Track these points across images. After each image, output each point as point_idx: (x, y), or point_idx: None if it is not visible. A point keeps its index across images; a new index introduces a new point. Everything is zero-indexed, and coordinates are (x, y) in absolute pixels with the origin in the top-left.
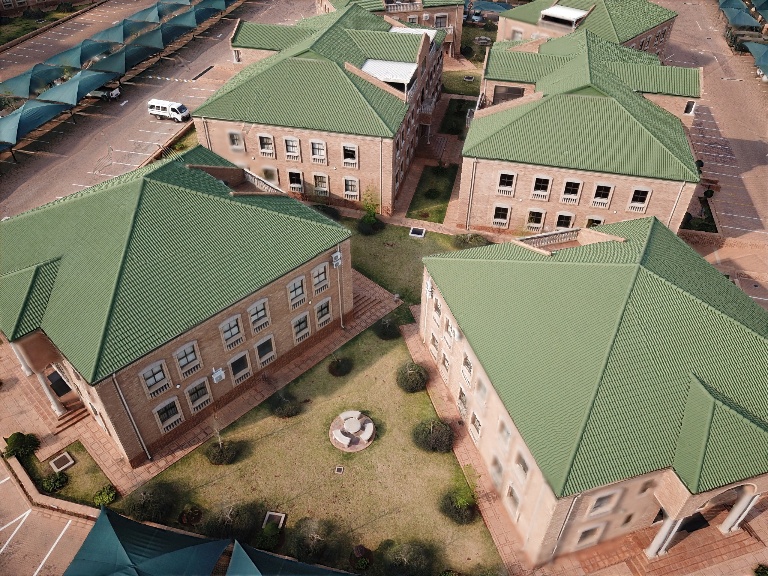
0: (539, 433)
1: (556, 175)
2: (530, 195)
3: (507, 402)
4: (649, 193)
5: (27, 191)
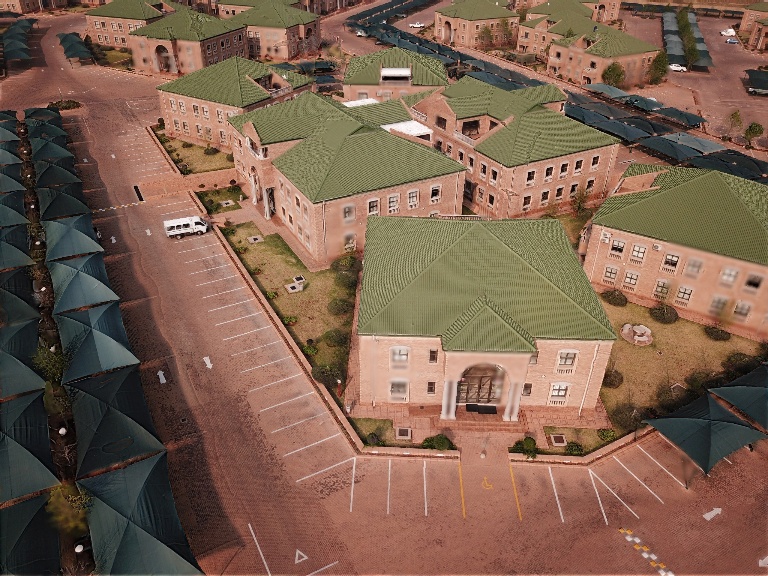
0: (764, 256)
1: (556, 162)
2: (543, 181)
3: (733, 254)
4: (600, 157)
5: (178, 334)
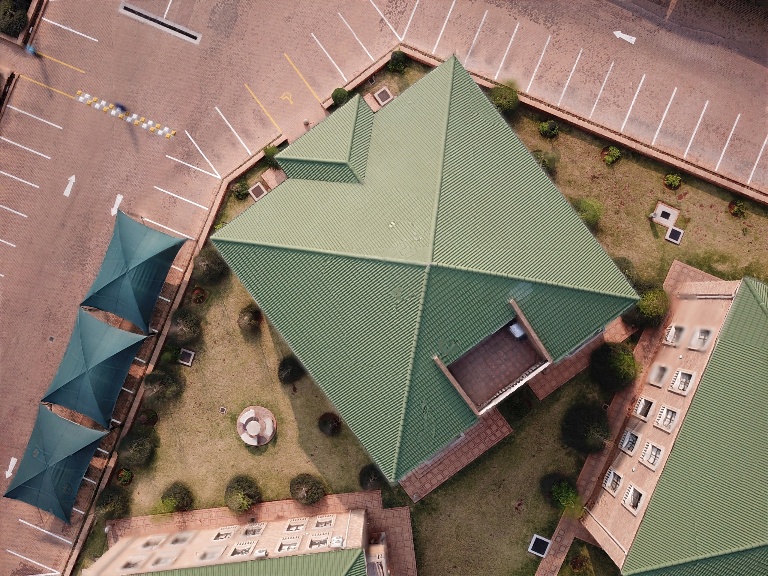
0: None
1: None
2: None
3: (155, 575)
4: None
5: (697, 46)
